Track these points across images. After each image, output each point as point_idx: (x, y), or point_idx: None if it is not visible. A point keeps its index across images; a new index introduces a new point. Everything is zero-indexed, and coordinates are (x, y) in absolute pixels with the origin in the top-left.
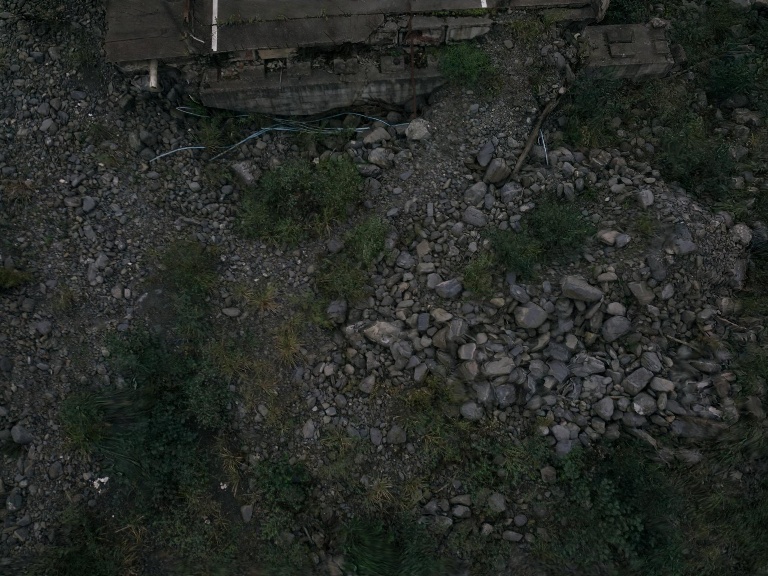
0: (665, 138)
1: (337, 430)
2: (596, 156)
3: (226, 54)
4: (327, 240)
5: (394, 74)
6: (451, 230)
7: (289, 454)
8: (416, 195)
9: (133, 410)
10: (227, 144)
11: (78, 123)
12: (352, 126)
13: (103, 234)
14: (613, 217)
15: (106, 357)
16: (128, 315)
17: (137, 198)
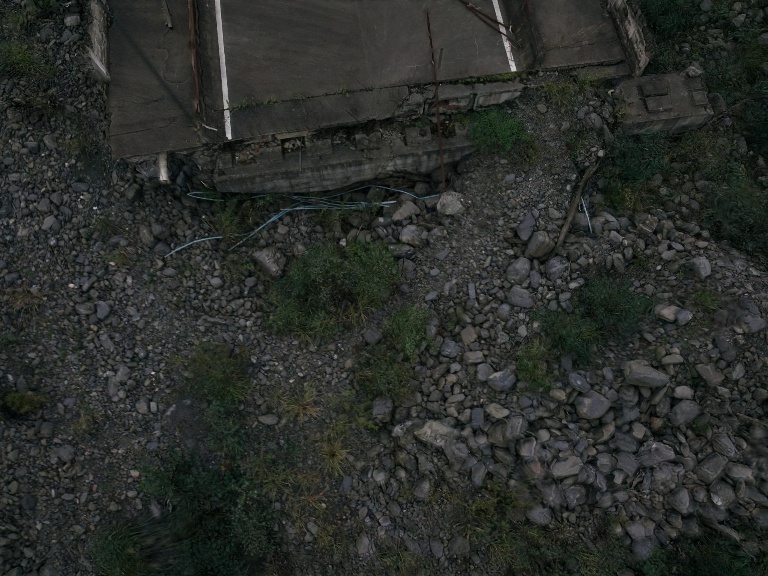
0: (710, 193)
1: (394, 542)
2: (643, 222)
3: None
4: (363, 330)
5: (421, 146)
6: (497, 313)
7: (344, 573)
8: (455, 276)
9: (172, 540)
10: (246, 231)
11: (83, 219)
12: (377, 200)
13: (121, 342)
14: (668, 288)
15: (135, 477)
16: (157, 432)
17: (154, 298)
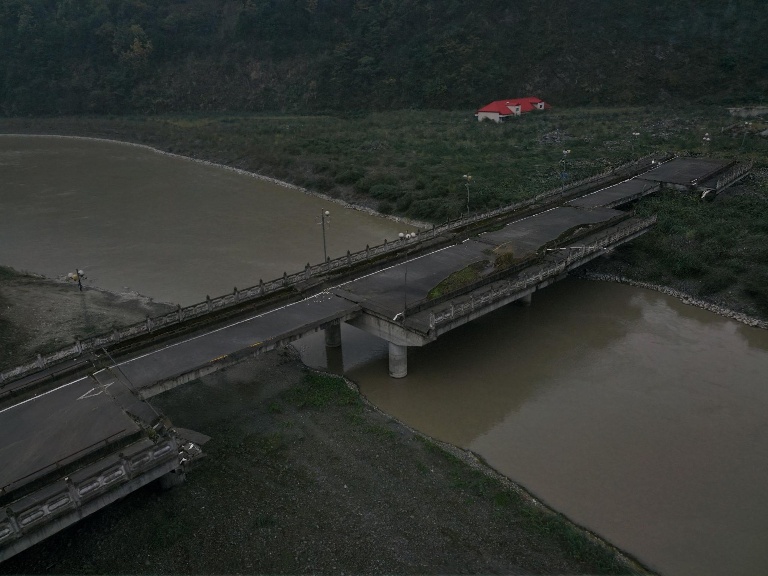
0: None
1: None
2: None
3: None
4: None
5: None
6: None
7: None
8: None
9: None
10: None
11: (766, 175)
12: None
13: None
14: None
15: None
16: (762, 167)
17: None
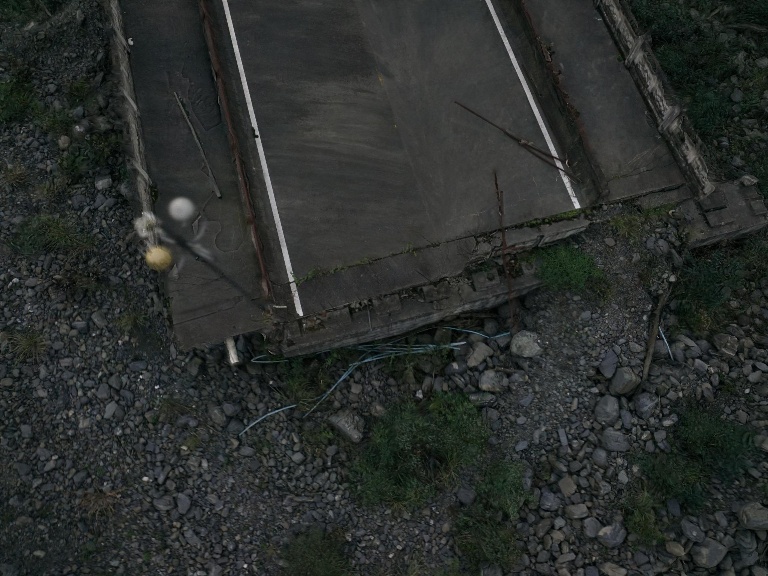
0: None
1: None
2: (724, 345)
3: None
4: (455, 488)
5: (490, 290)
6: (593, 459)
7: None
8: (543, 422)
9: None
10: (318, 394)
11: (146, 401)
12: (446, 343)
13: (207, 536)
14: (763, 415)
15: None
16: None
17: (234, 482)
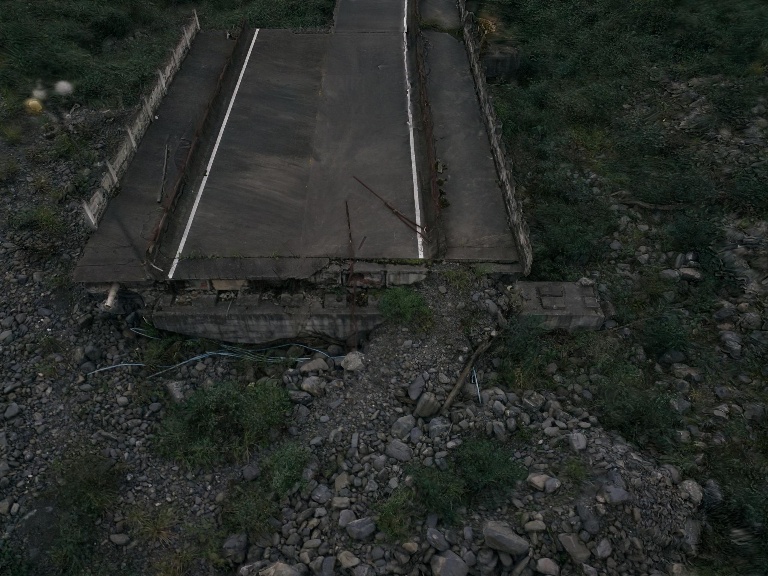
0: (602, 386)
1: None
2: (528, 397)
3: (182, 283)
4: (244, 466)
5: (336, 310)
6: (373, 463)
7: None
8: (342, 424)
9: None
10: (168, 364)
11: (34, 336)
12: (294, 356)
13: (15, 442)
14: (545, 460)
15: None
16: (6, 534)
17: (63, 409)
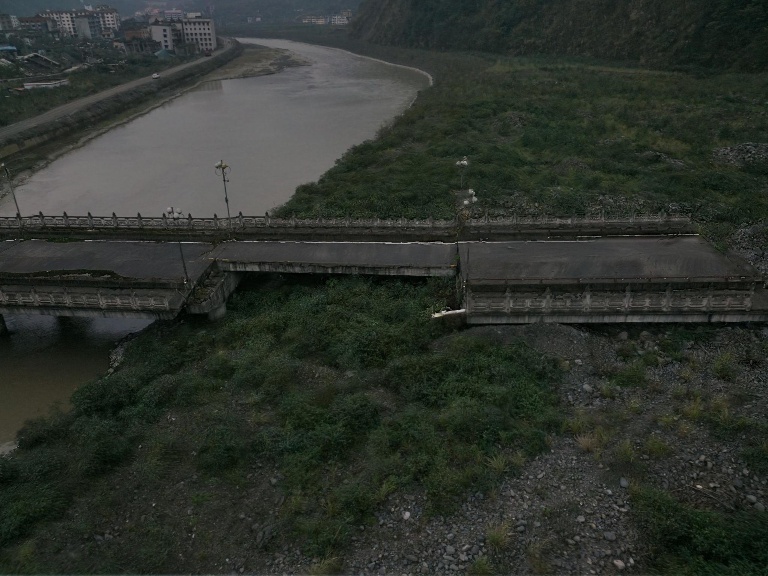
0: None
1: None
2: None
3: None
4: None
5: None
6: None
7: None
8: None
9: None
10: None
11: None
12: None
13: None
14: (762, 235)
15: None
16: None
17: None
